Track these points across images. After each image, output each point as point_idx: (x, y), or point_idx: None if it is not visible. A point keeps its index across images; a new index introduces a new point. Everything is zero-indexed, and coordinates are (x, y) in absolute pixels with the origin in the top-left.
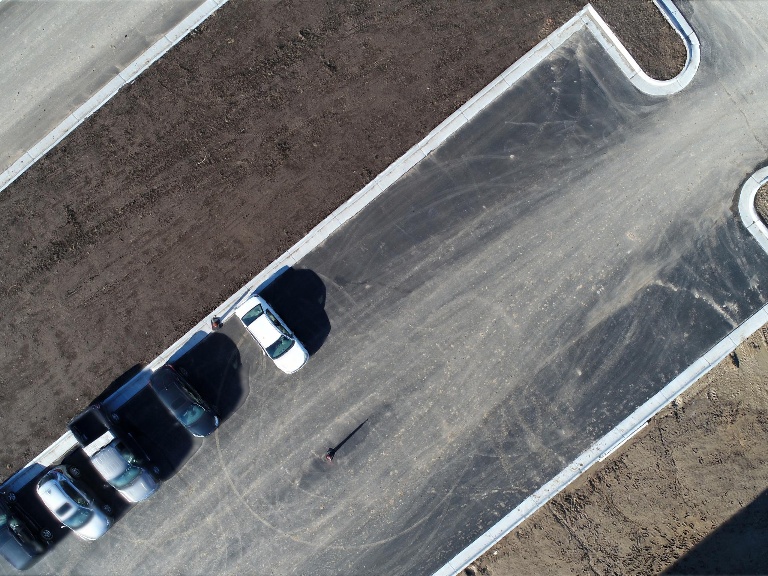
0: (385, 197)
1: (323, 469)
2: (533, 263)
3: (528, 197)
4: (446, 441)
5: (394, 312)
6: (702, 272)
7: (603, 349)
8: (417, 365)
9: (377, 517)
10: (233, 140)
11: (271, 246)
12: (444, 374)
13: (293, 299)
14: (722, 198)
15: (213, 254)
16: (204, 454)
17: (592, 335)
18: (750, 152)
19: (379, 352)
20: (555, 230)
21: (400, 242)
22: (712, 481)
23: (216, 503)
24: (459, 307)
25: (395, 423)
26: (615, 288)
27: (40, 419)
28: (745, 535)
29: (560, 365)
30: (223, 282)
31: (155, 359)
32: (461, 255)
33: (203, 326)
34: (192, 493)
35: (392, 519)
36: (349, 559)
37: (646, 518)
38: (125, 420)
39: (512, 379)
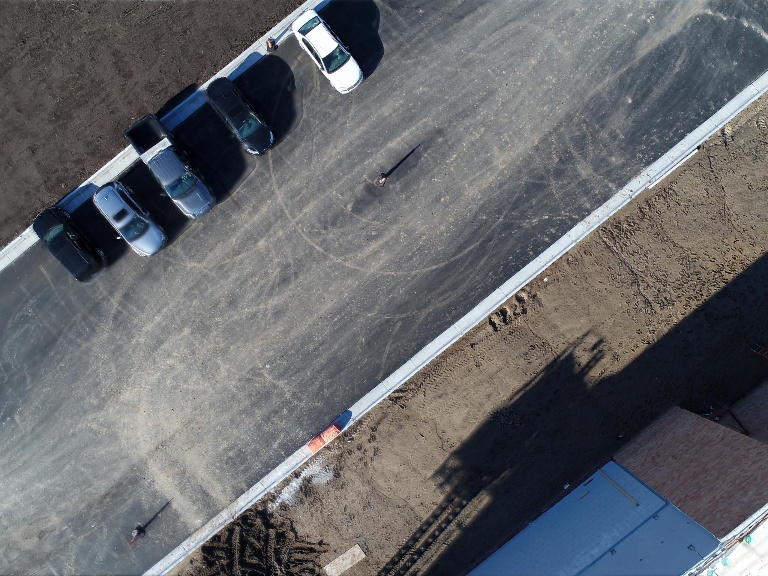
0: None
1: (375, 194)
2: None
3: None
4: (497, 168)
5: (447, 37)
6: (751, 1)
7: (653, 77)
8: (469, 91)
9: (428, 243)
10: None
11: None
12: (496, 100)
13: (347, 22)
14: None
15: None
16: (257, 177)
17: (642, 63)
18: None
19: (432, 77)
20: None
21: None
22: (761, 207)
23: (269, 227)
24: (511, 33)
25: (447, 149)
26: (665, 17)
27: (96, 138)
28: None
29: (610, 93)
30: (279, 2)
31: (210, 78)
32: None
33: (258, 47)
34: (245, 216)
35: (443, 245)
36: (400, 285)
37: (696, 243)
38: (180, 141)
39: (563, 106)
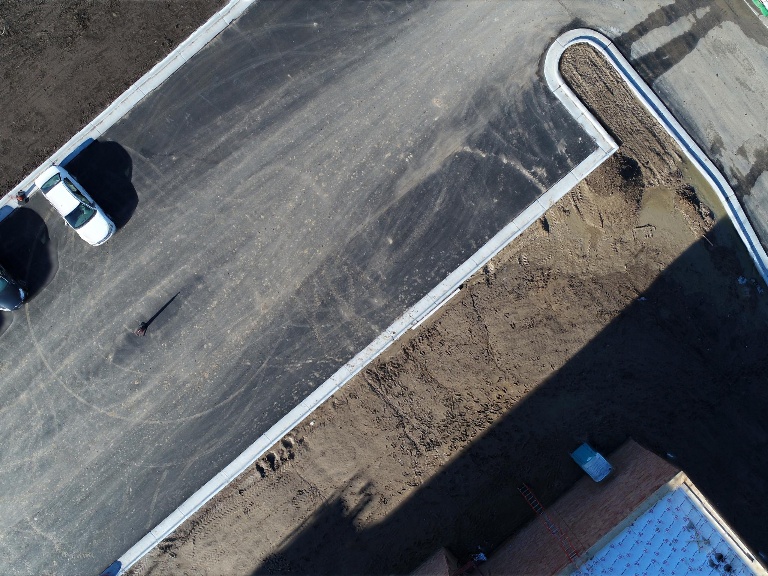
0: (188, 67)
1: (136, 343)
2: (340, 131)
3: (333, 65)
4: (259, 313)
5: (202, 184)
6: (510, 137)
7: (413, 217)
8: (227, 237)
9: (192, 391)
10: (32, 12)
11: (74, 118)
12: (255, 245)
13: (99, 172)
14: (528, 63)
15: (15, 127)
16: (15, 331)
17: (402, 203)
18: (554, 16)
19: (188, 224)
20: (361, 98)
21: (205, 113)
22: (524, 345)
23: (29, 380)
24: (267, 177)
25: (207, 296)
26: (424, 155)
27: None
28: (558, 398)
29: (371, 234)
30: (27, 155)
31: None
32: (268, 125)
33: (9, 201)
34: (5, 370)
35: (207, 392)
36: (165, 433)
37: (459, 384)
38: None
39: (323, 249)
